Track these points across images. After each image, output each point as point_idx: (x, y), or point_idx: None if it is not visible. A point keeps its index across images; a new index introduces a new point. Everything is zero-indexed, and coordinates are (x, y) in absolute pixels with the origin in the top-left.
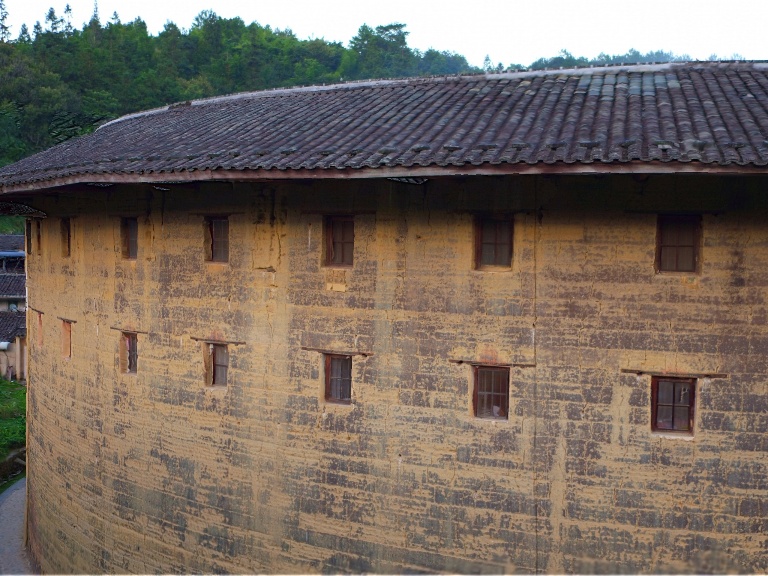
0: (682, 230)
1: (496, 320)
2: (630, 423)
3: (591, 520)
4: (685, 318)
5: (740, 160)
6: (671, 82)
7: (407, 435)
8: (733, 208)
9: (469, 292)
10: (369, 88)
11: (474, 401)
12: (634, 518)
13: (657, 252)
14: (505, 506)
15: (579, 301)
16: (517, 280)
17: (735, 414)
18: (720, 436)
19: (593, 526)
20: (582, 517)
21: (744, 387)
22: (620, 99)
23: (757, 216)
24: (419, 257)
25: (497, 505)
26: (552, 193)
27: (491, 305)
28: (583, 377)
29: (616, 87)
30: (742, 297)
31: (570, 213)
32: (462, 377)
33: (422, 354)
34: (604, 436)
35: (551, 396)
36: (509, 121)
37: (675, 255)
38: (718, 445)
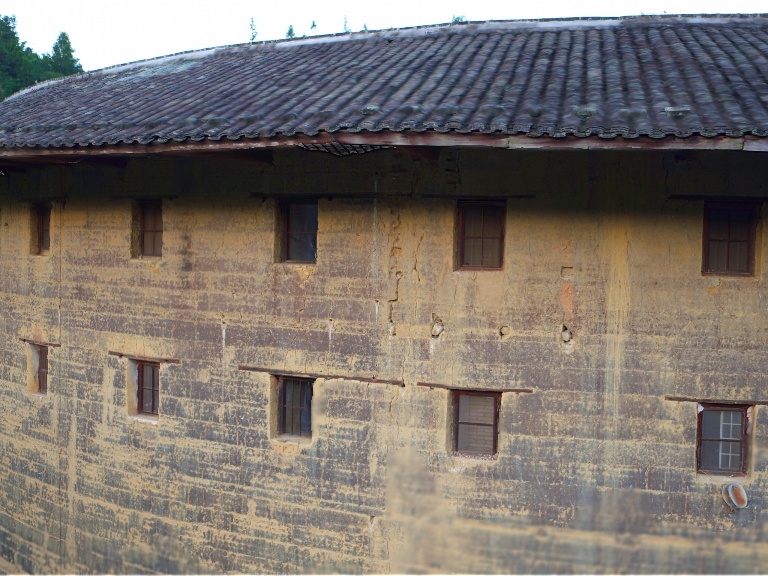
0: (157, 215)
1: (41, 301)
2: (114, 404)
3: (90, 496)
4: (150, 302)
5: (21, 142)
6: (182, 68)
7: (0, 406)
8: (183, 192)
9: (28, 275)
10: (43, 89)
11: (40, 378)
12: (116, 497)
13: (140, 237)
14: (44, 477)
15: (84, 284)
16: (51, 264)
17: (185, 400)
18: (175, 422)
19: (91, 502)
20: (85, 493)
21: (192, 373)
22: (105, 88)
23: (201, 200)
24: (6, 243)
25: (40, 476)
26: (70, 181)
27: (38, 287)
28: (86, 358)
29: (137, 76)
30: (190, 282)
31: (79, 200)
32: (24, 354)
33: (7, 332)
34: (98, 415)
35: (68, 375)
36: (3, 114)
37: (152, 240)
38: (173, 431)
